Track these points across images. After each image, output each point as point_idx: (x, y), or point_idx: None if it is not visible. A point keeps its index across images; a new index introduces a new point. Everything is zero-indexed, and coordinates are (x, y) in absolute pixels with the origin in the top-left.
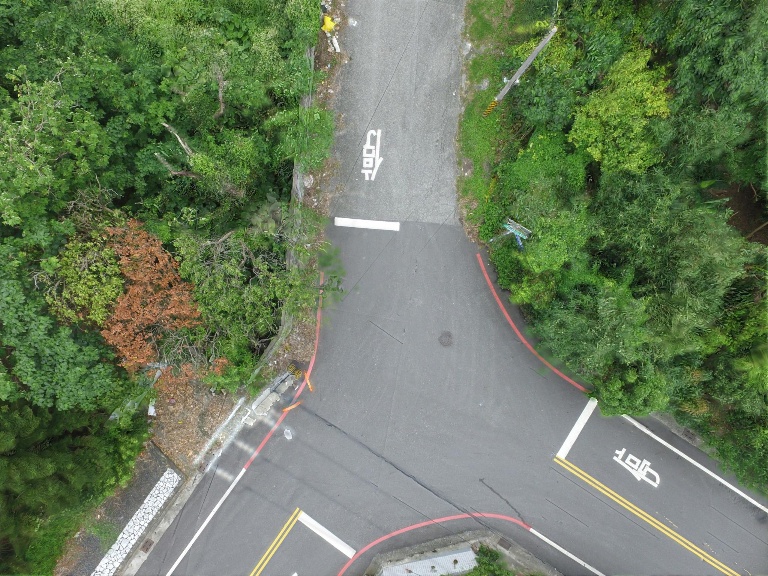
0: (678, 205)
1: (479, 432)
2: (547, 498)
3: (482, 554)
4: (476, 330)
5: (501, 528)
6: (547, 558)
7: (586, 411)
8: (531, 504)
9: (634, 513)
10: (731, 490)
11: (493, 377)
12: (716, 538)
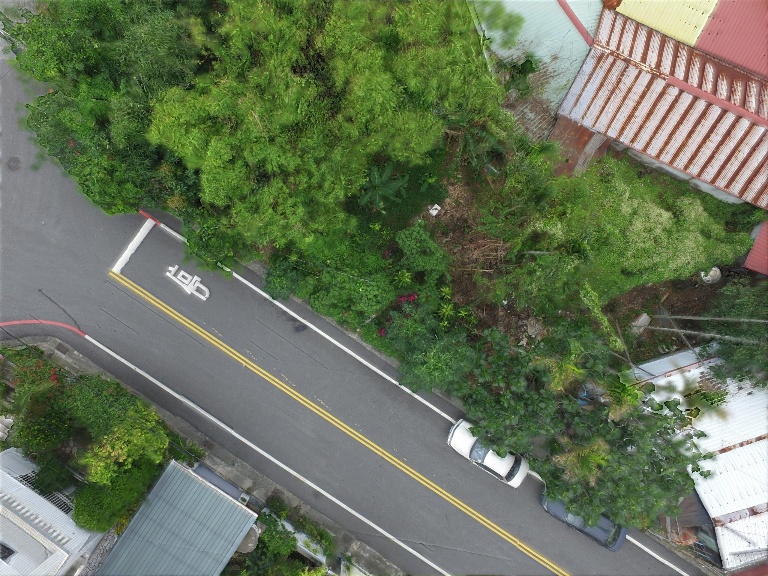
0: (202, 36)
1: (40, 247)
2: (101, 308)
3: (22, 349)
4: (44, 157)
5: (59, 335)
6: (101, 362)
7: (143, 231)
8: (87, 313)
9: (183, 323)
10: (275, 305)
11: (57, 199)
12: (258, 347)
